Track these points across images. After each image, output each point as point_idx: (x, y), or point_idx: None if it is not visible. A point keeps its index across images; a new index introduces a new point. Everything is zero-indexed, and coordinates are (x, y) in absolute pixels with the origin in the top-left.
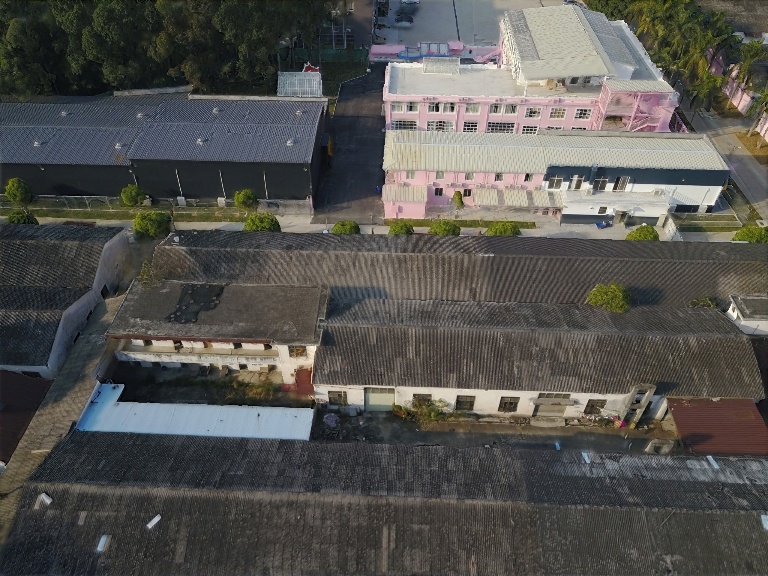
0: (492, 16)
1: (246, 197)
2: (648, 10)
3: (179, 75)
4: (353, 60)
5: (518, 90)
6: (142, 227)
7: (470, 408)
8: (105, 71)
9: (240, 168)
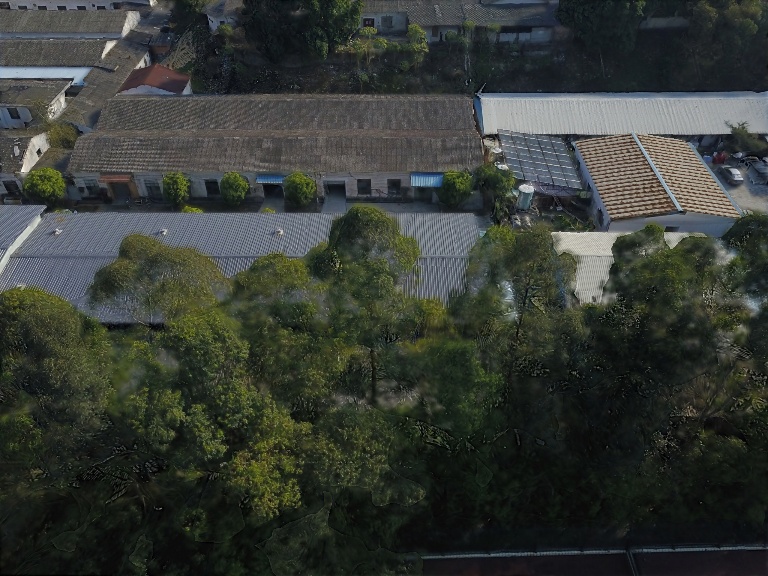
0: None
1: None
2: None
3: None
4: None
5: None
6: None
7: None
8: None
9: None
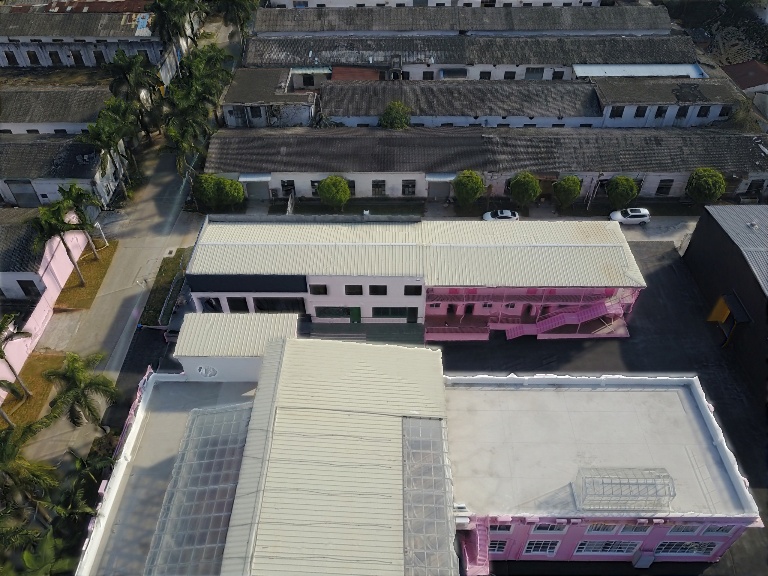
0: None
1: None
2: None
3: None
4: None
5: None
6: None
7: None
8: None
9: None
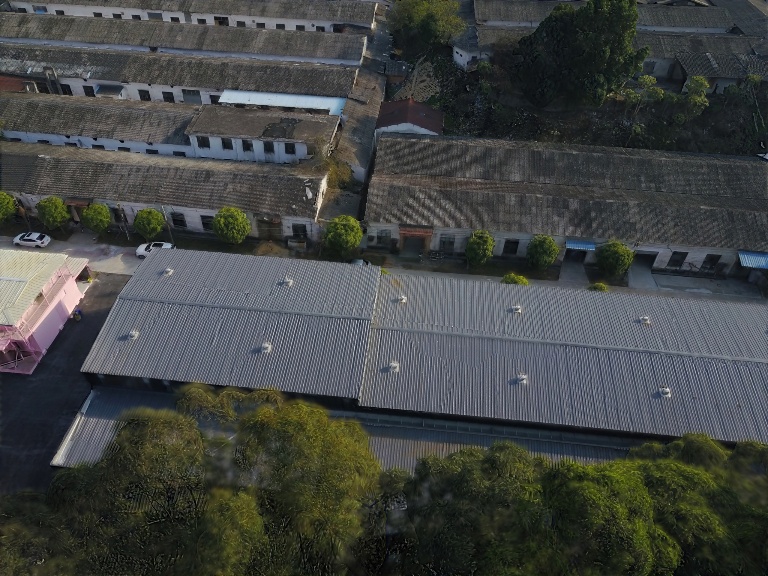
0: None
1: None
2: None
3: None
4: None
5: None
6: None
7: None
8: None
9: None
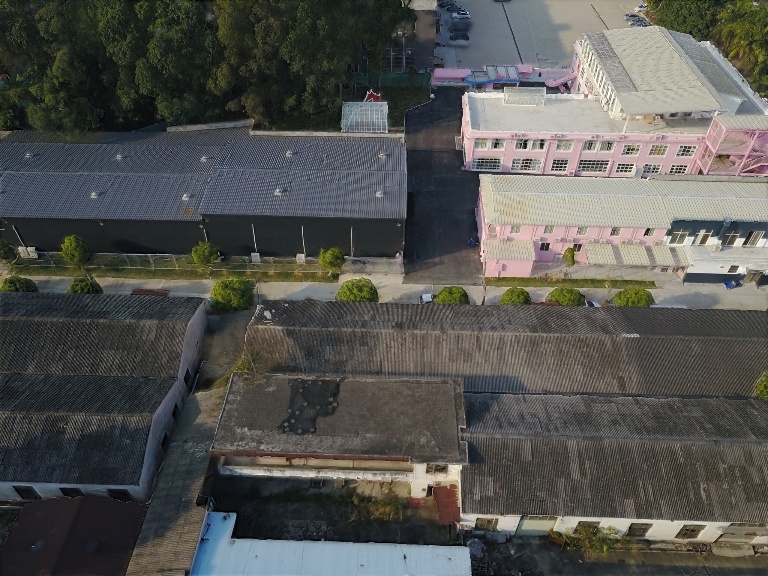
0: (551, 32)
1: (334, 257)
2: (744, 33)
3: (239, 109)
4: (414, 84)
5: (613, 124)
6: (224, 297)
7: (641, 534)
8: (160, 106)
9: (325, 223)
